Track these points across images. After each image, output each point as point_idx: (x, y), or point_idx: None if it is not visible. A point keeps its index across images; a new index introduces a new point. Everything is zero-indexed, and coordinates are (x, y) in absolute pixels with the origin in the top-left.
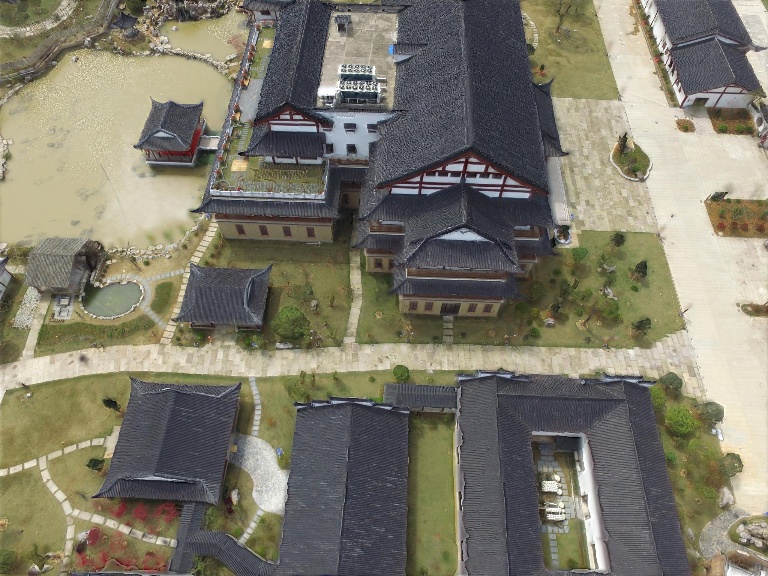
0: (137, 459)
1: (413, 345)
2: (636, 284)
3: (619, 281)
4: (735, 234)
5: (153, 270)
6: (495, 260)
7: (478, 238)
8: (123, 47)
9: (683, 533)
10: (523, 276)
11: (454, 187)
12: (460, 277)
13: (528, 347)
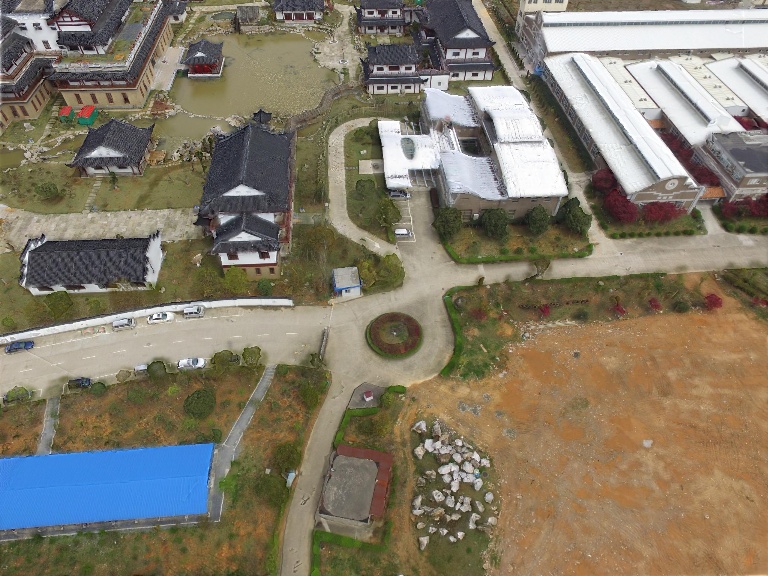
0: None
1: None
2: None
3: None
4: None
5: (208, 24)
6: None
7: None
8: None
9: None
10: None
11: None
12: None
13: None
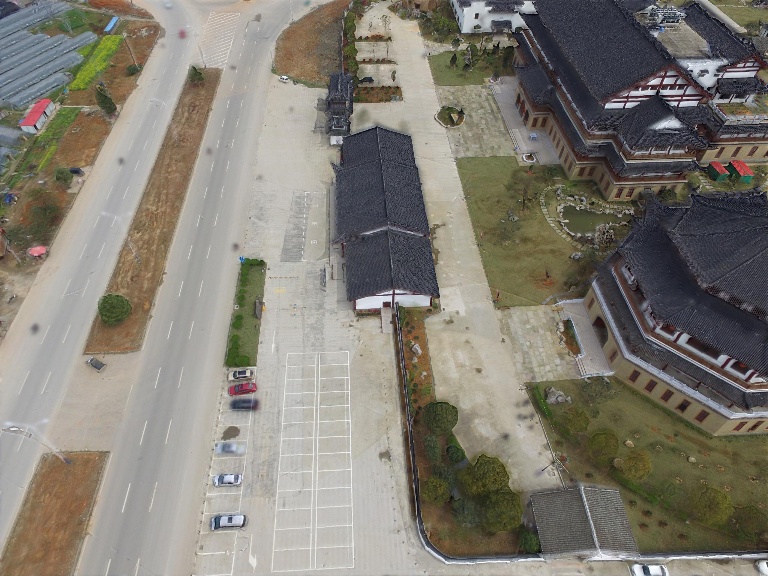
0: (650, 1)
1: None
2: None
3: (461, 66)
4: None
5: None
6: None
7: None
8: None
9: None
10: None
11: None
12: None
13: None
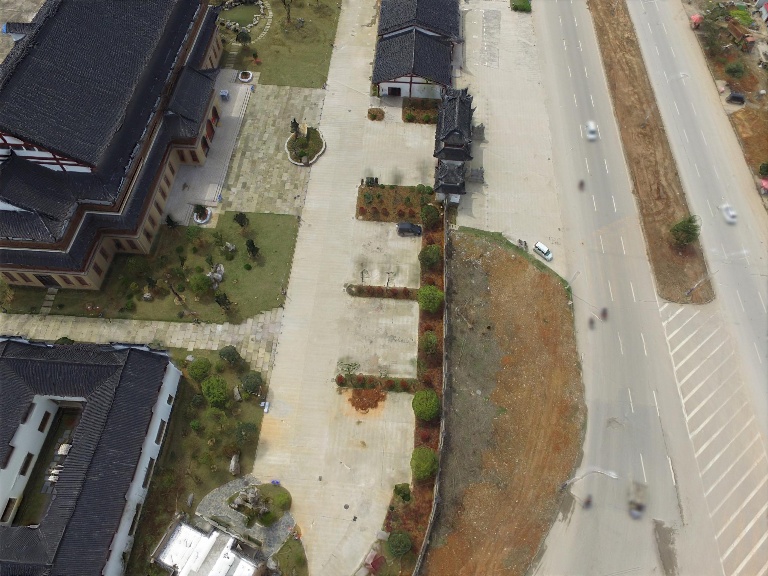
0: None
1: (9, 315)
2: (252, 263)
3: (237, 260)
4: (374, 218)
5: None
6: (35, 230)
7: (17, 208)
8: None
9: (167, 496)
10: (142, 252)
11: (9, 159)
12: (20, 247)
13: (120, 320)
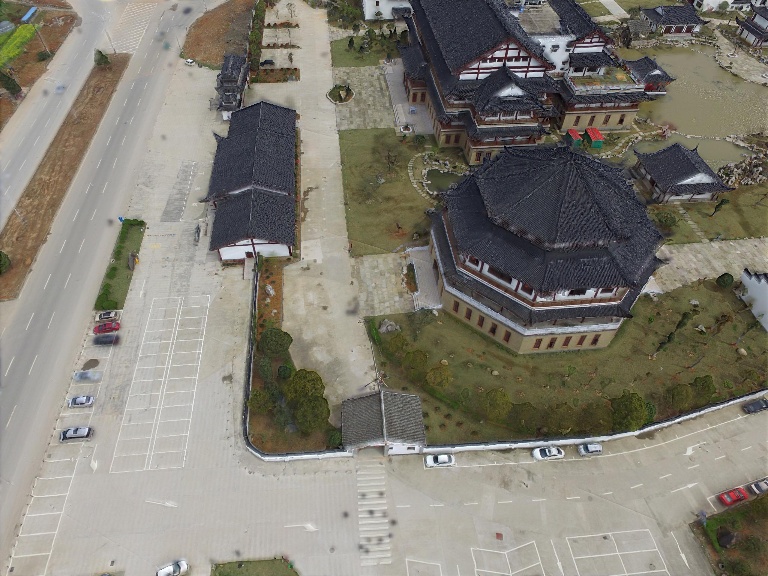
0: None
1: None
2: None
3: None
4: None
5: None
6: None
7: None
8: (765, 139)
9: None
10: None
11: None
12: None
13: None
